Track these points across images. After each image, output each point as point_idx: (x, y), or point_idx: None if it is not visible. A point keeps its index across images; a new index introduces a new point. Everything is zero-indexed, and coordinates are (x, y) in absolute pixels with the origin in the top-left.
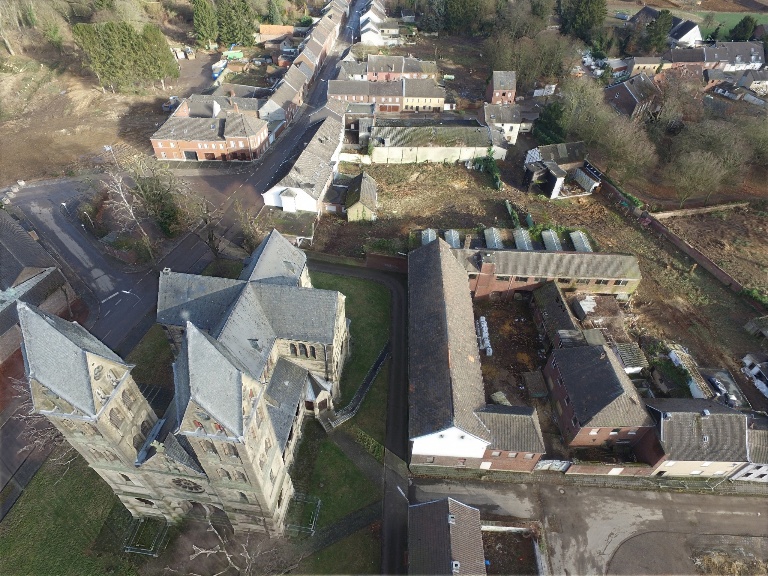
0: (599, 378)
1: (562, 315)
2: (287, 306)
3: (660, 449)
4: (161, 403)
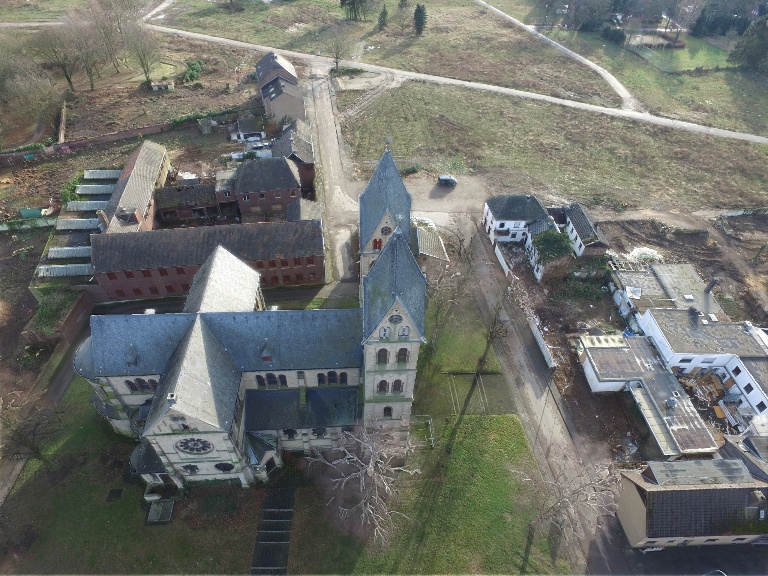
0: (270, 168)
1: (197, 190)
2: (227, 290)
3: (310, 165)
4: (286, 496)
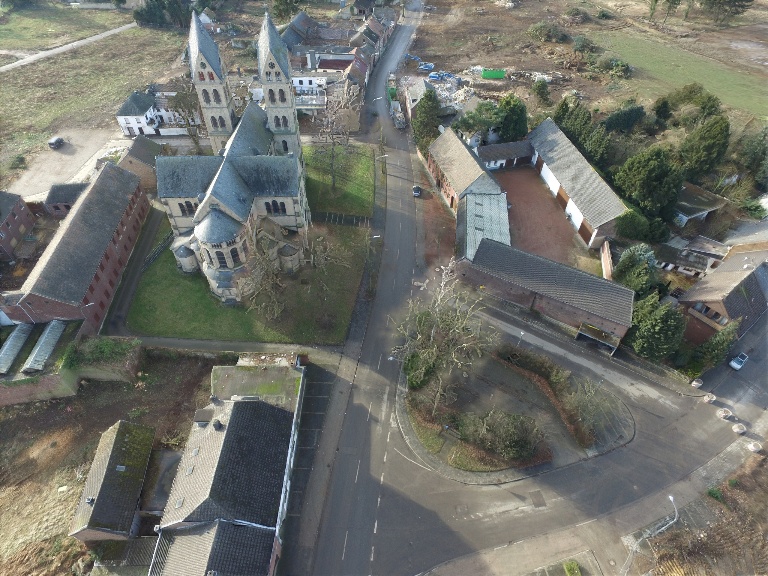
0: None
1: None
2: None
3: None
4: (320, 215)
